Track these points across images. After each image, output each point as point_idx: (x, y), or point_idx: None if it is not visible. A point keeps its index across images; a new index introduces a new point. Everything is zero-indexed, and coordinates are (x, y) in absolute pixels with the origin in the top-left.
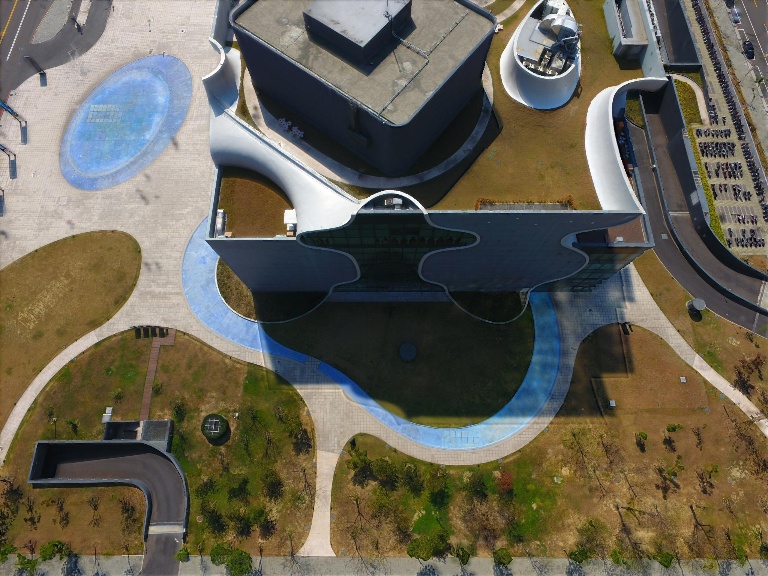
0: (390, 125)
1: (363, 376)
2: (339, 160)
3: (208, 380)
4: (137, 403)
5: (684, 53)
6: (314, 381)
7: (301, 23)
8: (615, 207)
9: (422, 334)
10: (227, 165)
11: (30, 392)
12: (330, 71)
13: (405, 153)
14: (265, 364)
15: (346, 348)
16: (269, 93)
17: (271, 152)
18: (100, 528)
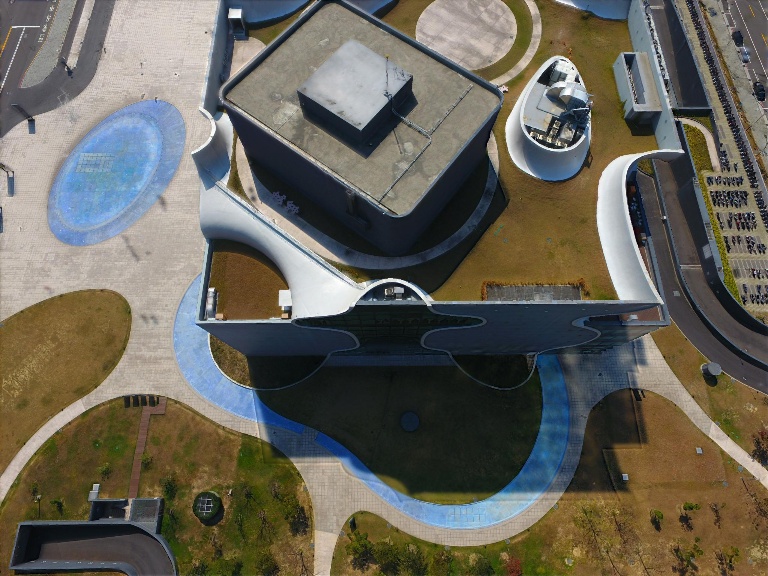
0: (390, 216)
1: (363, 448)
2: (336, 238)
3: (200, 453)
4: (126, 479)
5: (693, 95)
6: (312, 454)
7: (295, 99)
8: (630, 292)
9: (425, 401)
10: (218, 238)
11: (13, 467)
12: (326, 153)
13: (406, 236)
14: (260, 435)
15: (345, 417)
16: (263, 163)
17: (265, 228)
18: None
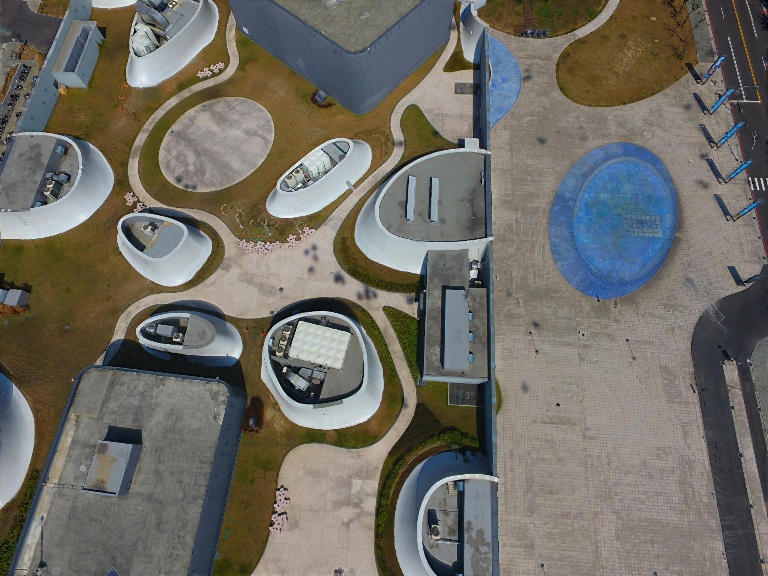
0: None
1: None
2: None
3: (485, 7)
4: None
5: None
6: None
7: None
8: None
9: None
10: None
11: (613, 6)
12: None
13: None
14: None
15: None
16: None
17: None
18: None
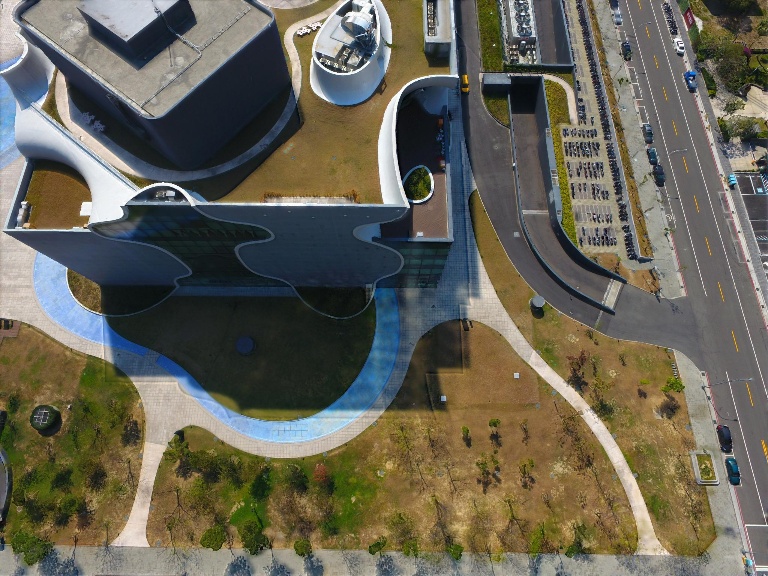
0: (145, 118)
1: (200, 369)
2: (136, 153)
3: (46, 372)
4: None
5: (562, 54)
6: (151, 374)
7: None
8: (393, 201)
9: (264, 328)
10: (39, 158)
11: None
12: (103, 65)
13: (186, 146)
14: (105, 356)
15: (187, 341)
16: (78, 87)
17: (72, 145)
18: None
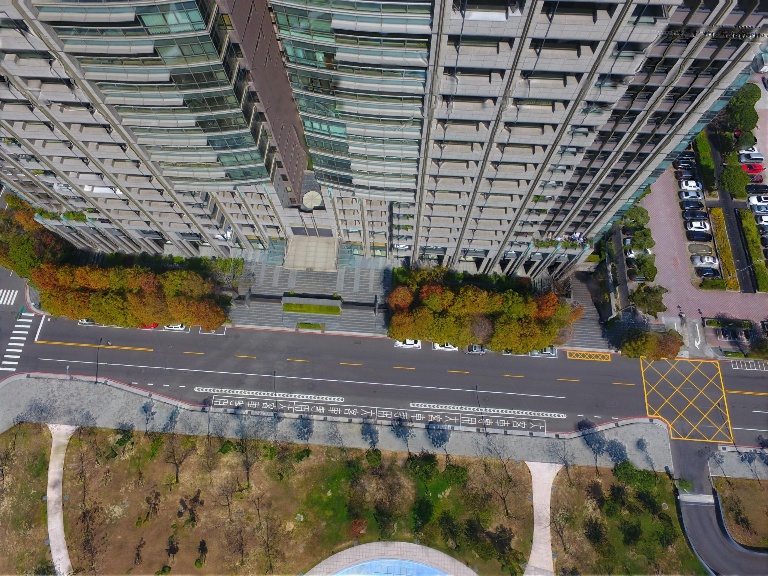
0: None
1: None
2: None
3: None
4: None
5: None
6: None
7: None
8: None
9: None
10: None
11: None
12: None
13: None
14: None
15: None
16: None
17: None
18: (764, 505)
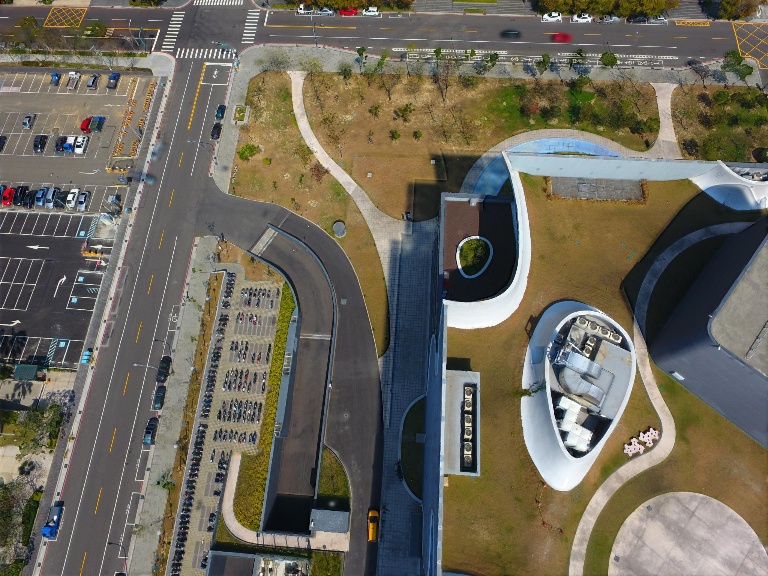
0: None
1: None
2: None
3: None
4: None
5: None
6: None
7: None
8: None
9: None
10: None
11: None
12: None
13: None
14: None
15: None
16: None
17: None
18: None
